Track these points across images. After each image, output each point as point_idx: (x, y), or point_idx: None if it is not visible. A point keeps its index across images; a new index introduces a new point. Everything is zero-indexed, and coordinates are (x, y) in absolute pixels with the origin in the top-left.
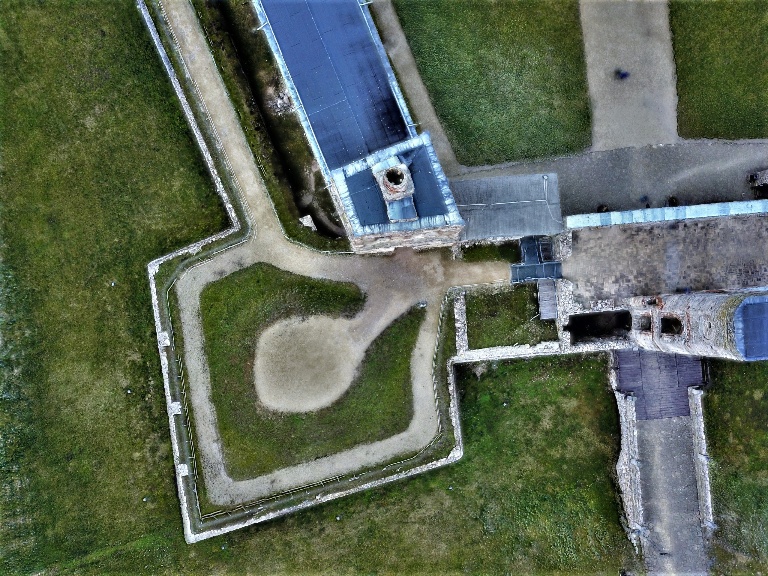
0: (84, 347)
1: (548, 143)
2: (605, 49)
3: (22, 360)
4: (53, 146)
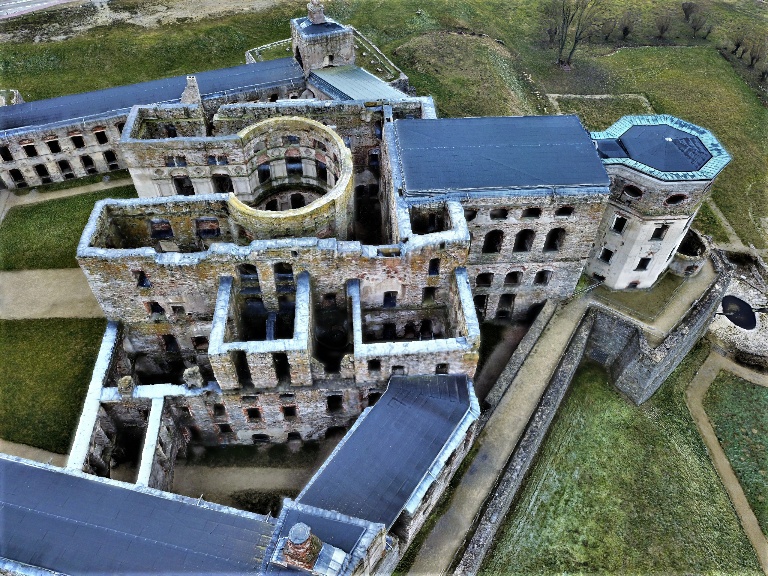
0: (2, 88)
1: (1, 248)
2: (54, 279)
3: (7, 70)
4: (112, 83)
